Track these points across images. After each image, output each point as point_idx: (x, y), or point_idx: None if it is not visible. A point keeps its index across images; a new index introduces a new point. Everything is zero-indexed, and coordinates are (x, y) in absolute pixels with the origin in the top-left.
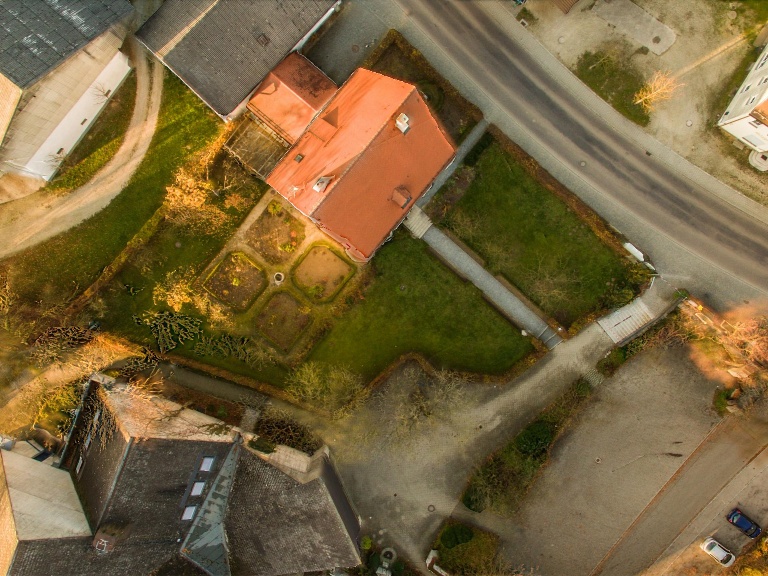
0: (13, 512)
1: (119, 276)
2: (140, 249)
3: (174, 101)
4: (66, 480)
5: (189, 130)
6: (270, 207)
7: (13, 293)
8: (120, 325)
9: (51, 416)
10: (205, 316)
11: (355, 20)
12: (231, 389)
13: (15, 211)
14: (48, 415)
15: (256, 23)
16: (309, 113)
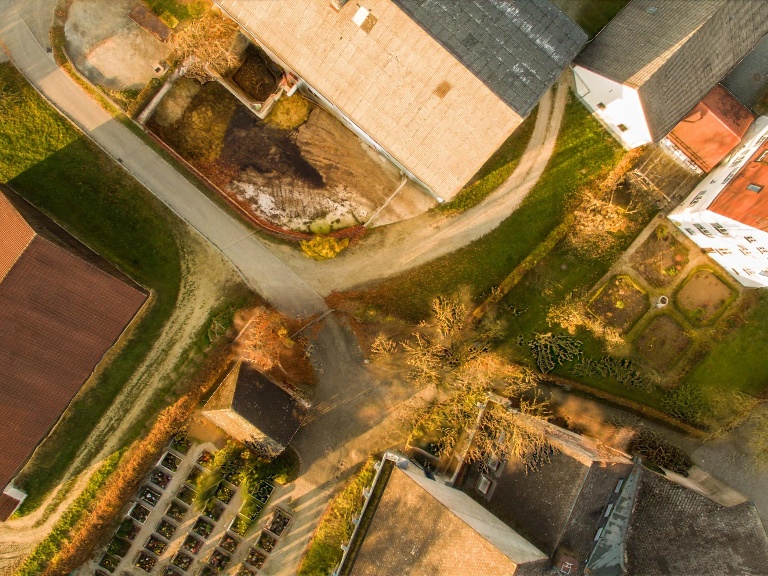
0: (481, 535)
1: (505, 297)
2: (538, 271)
3: (574, 126)
4: (471, 500)
5: (586, 154)
6: (659, 231)
7: (463, 317)
8: (503, 346)
9: (425, 435)
10: (594, 338)
11: (759, 49)
12: (604, 410)
13: (403, 231)
14: (423, 434)
15: (709, 54)
16: (733, 141)
